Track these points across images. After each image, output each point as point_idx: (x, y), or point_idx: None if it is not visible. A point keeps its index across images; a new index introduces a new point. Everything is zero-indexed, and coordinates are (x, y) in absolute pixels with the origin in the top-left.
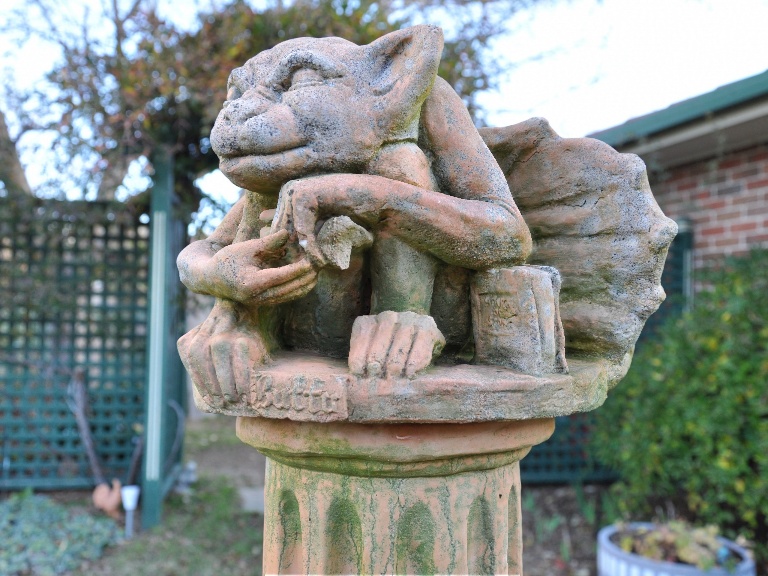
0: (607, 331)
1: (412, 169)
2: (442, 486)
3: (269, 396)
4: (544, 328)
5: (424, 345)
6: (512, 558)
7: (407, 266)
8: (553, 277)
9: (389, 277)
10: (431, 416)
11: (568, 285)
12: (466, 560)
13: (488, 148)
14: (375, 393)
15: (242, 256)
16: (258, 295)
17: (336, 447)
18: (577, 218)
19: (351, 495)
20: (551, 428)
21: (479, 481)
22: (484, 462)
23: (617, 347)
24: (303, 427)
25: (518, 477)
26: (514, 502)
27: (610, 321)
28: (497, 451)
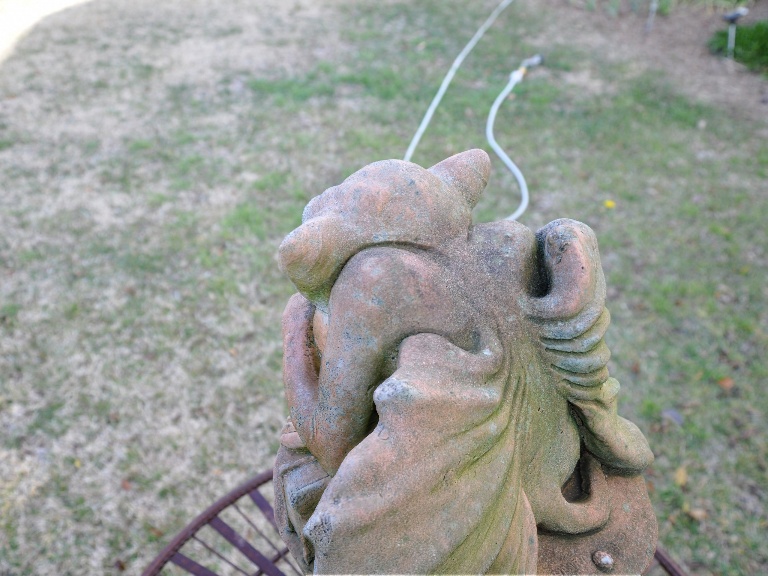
0: None
1: (318, 334)
2: None
3: None
4: None
5: (293, 438)
6: None
7: None
8: None
9: None
10: None
11: None
12: None
13: (353, 369)
14: None
15: None
16: None
17: None
18: None
19: None
20: None
21: None
22: None
23: None
24: None
25: None
26: None
27: None
28: None
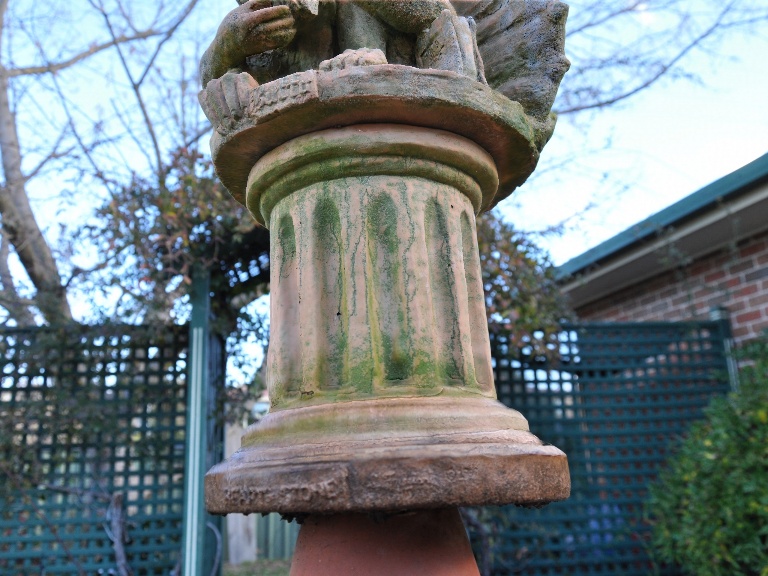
0: (528, 92)
1: None
2: (400, 182)
3: (263, 98)
4: (464, 49)
5: None
6: (471, 274)
7: (362, 24)
8: (469, 21)
9: (350, 34)
10: (379, 92)
11: (498, 72)
12: (424, 238)
13: None
14: (337, 77)
15: (242, 9)
16: (253, 30)
17: (315, 145)
18: (497, 18)
19: (330, 193)
20: (491, 164)
21: (432, 187)
22: (433, 166)
23: (538, 104)
24: (291, 142)
25: (472, 217)
26: (469, 231)
27: (529, 84)
28: (440, 151)
